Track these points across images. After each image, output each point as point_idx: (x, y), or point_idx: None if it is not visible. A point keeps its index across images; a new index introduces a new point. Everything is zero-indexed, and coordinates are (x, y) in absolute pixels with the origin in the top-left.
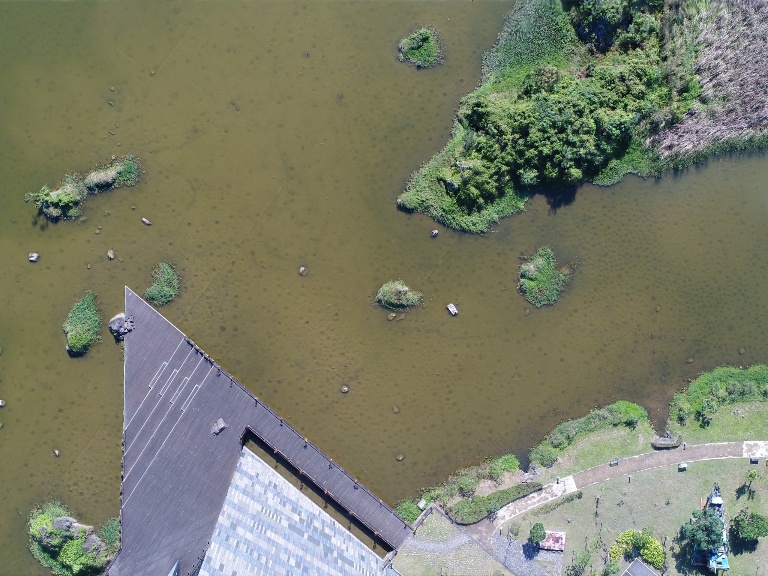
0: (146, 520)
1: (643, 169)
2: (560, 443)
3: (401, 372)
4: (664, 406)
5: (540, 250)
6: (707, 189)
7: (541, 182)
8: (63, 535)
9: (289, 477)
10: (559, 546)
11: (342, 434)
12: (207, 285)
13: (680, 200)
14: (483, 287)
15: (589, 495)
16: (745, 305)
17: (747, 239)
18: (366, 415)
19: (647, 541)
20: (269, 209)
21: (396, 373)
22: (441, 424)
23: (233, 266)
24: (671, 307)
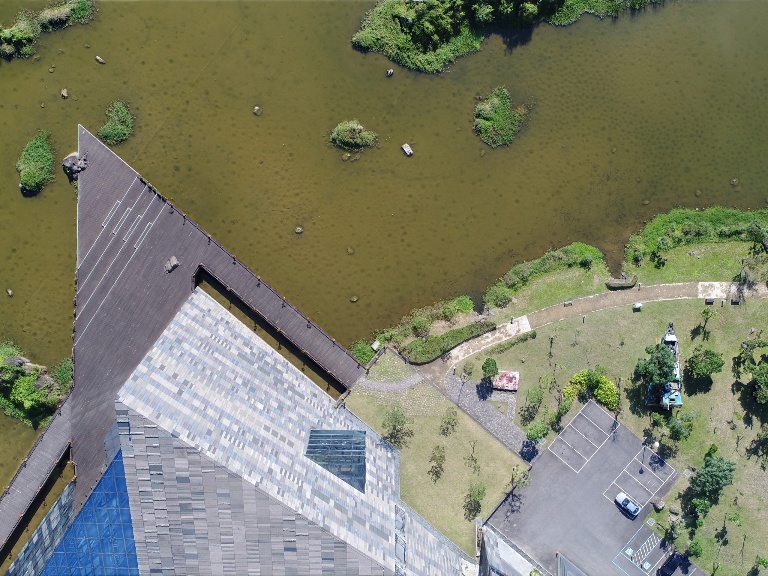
0: (98, 358)
1: (600, 8)
2: (514, 283)
3: (356, 213)
4: (620, 248)
5: (496, 90)
6: (664, 29)
7: (497, 21)
8: (14, 370)
9: (243, 318)
10: (513, 386)
11: (296, 275)
12: (161, 124)
13: (637, 40)
14: (438, 127)
15: (543, 335)
16: (702, 147)
17: (704, 80)
18: (320, 256)
19: (601, 381)
20: (224, 48)
21: (351, 214)
22: (395, 265)
23: (187, 105)
24: (627, 148)
